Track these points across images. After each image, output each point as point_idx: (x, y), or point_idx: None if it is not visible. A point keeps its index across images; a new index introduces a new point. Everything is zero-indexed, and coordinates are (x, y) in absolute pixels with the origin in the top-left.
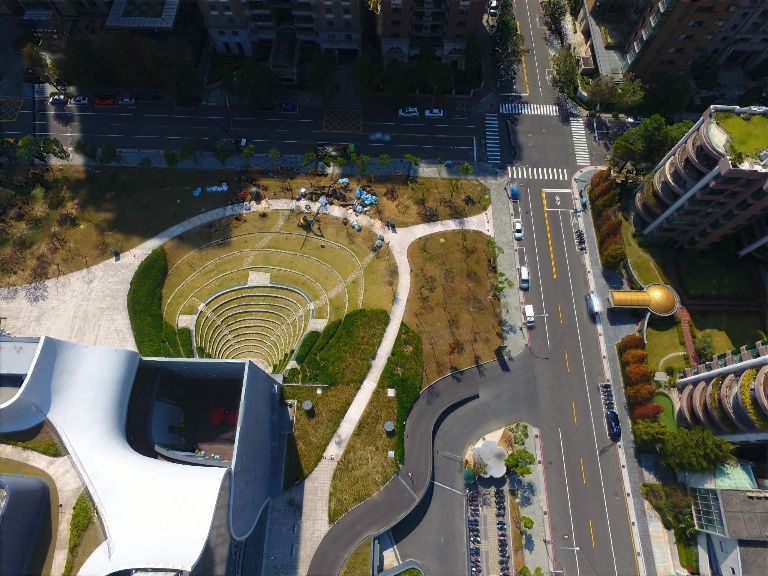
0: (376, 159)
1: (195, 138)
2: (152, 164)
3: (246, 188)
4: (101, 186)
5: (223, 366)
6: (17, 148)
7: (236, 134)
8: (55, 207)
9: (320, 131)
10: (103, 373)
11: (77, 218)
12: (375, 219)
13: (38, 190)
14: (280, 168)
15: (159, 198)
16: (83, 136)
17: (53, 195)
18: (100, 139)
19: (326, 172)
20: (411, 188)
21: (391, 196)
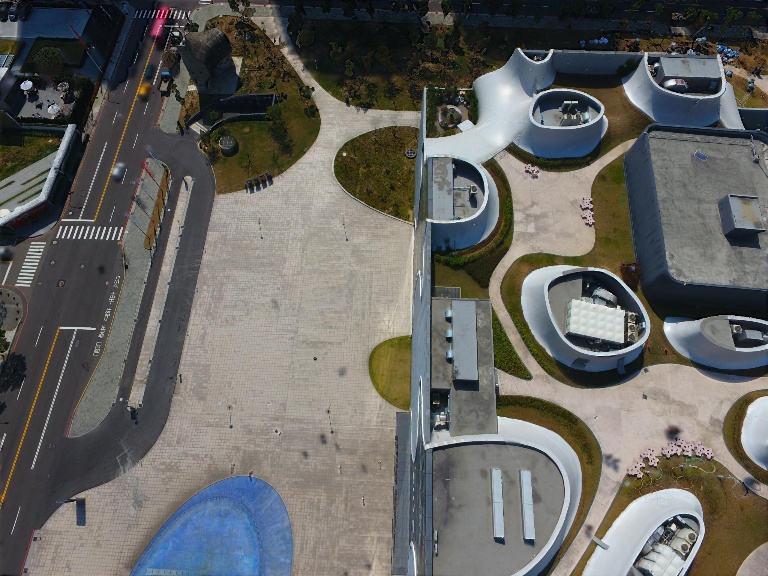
0: (719, 25)
1: (568, 2)
2: (526, 26)
3: (621, 42)
4: (494, 39)
5: (763, 123)
6: (402, 12)
7: (589, 4)
8: (461, 54)
9: (662, 3)
10: (733, 98)
11: (486, 61)
12: (740, 68)
13: (438, 42)
14: (641, 30)
15: (548, 49)
16: (455, 4)
17: (453, 46)
18: (472, 6)
19: (682, 33)
20: (761, 46)
21: (746, 52)
